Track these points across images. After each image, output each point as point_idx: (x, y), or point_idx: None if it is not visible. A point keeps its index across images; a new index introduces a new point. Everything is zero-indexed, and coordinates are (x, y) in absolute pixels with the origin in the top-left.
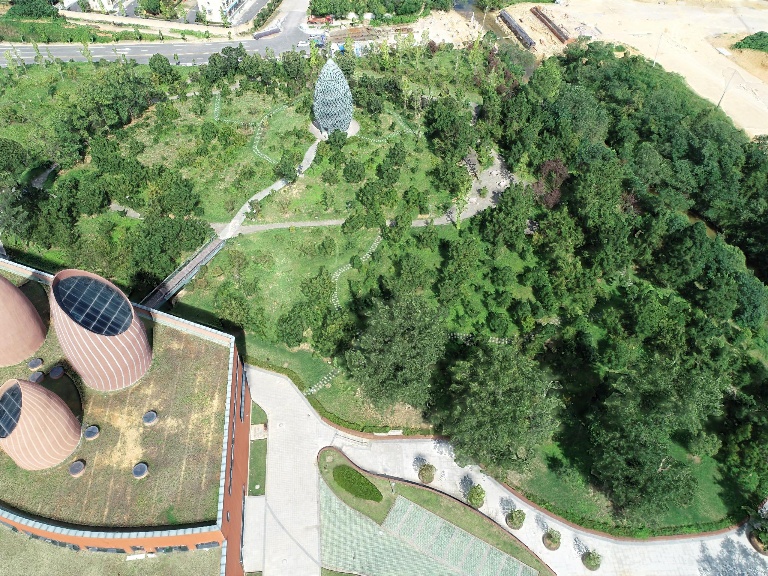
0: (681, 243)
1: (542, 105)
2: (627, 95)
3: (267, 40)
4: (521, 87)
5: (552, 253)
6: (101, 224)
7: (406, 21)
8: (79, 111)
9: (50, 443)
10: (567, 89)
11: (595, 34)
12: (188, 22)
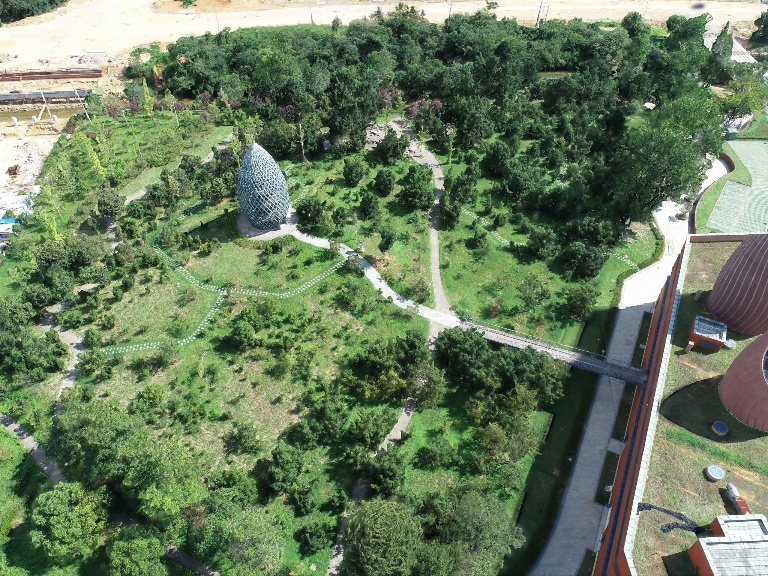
0: (505, 60)
1: None
2: None
3: None
4: None
5: (505, 112)
6: None
7: None
8: None
9: None
10: None
11: (103, 56)
12: None
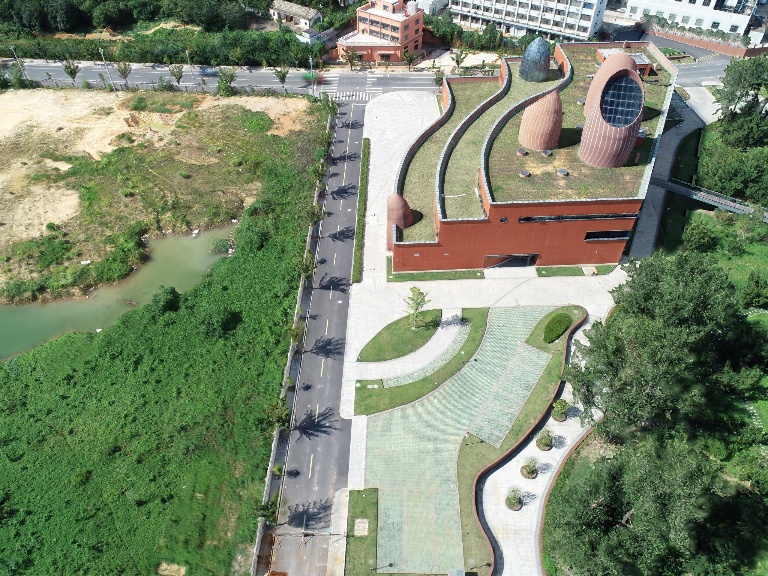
0: None
1: None
2: None
3: None
4: None
5: None
6: (762, 153)
7: None
8: None
9: (530, 130)
10: None
11: None
12: None
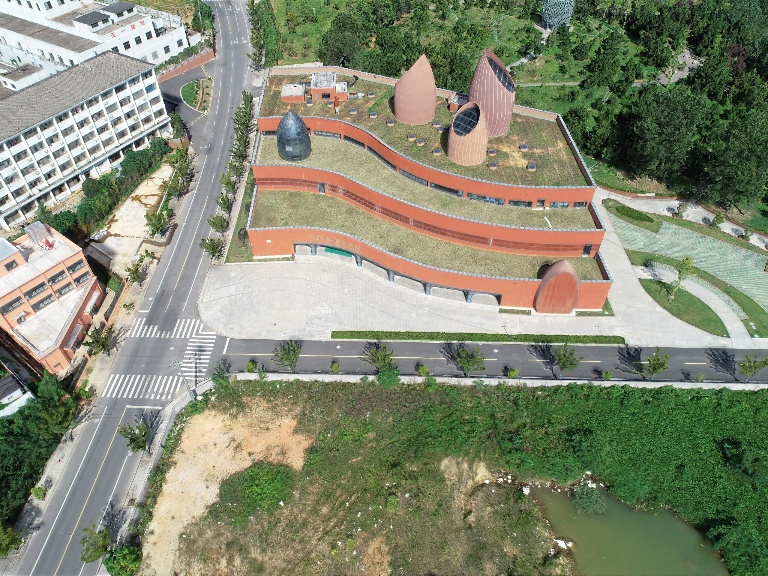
0: None
1: (717, 14)
2: None
3: None
4: None
5: None
6: None
7: None
8: (373, 7)
9: (483, 145)
10: (738, 1)
11: None
12: None
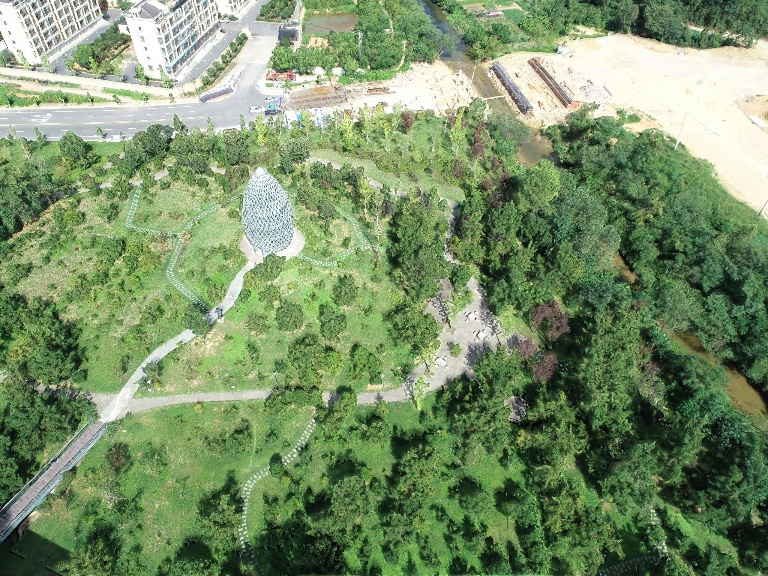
0: (725, 471)
1: (536, 213)
2: (643, 192)
3: (215, 103)
4: (512, 176)
5: None
6: None
7: (382, 77)
8: None
9: None
10: None
11: (604, 96)
12: (126, 78)
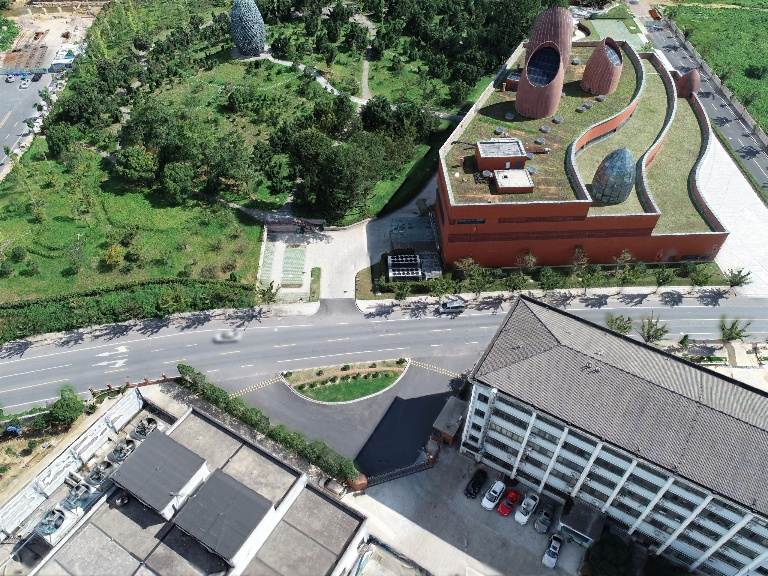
0: None
1: None
2: None
3: None
4: None
5: None
6: None
7: None
8: None
9: None
10: None
11: None
12: None
